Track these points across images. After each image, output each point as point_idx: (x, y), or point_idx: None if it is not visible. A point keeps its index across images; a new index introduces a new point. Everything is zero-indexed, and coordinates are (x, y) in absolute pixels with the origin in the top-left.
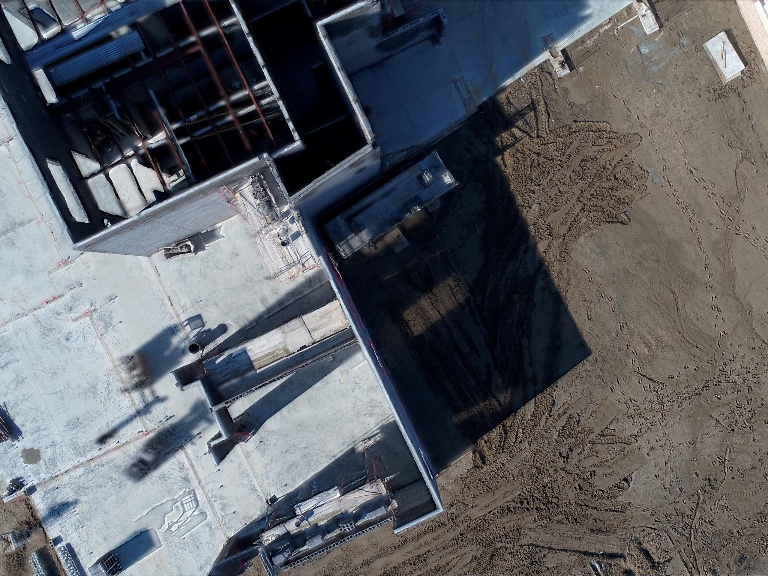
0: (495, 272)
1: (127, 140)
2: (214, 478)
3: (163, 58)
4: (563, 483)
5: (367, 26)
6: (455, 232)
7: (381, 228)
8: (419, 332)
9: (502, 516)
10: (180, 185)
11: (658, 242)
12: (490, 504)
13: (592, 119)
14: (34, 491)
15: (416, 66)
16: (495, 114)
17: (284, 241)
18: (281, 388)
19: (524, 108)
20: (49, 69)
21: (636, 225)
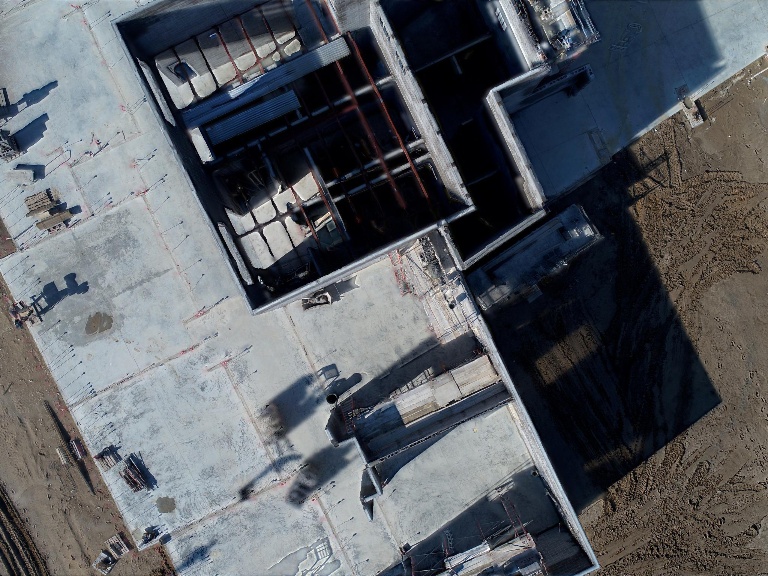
0: (627, 321)
1: (263, 191)
2: (348, 526)
3: (319, 117)
4: (693, 530)
5: (527, 87)
6: (587, 281)
7: (525, 282)
8: (551, 381)
9: (632, 563)
10: None
11: None
12: (620, 551)
13: (724, 169)
14: (169, 539)
15: (550, 117)
16: (628, 164)
17: (452, 304)
18: None
19: (657, 158)
20: (205, 128)
21: (767, 274)
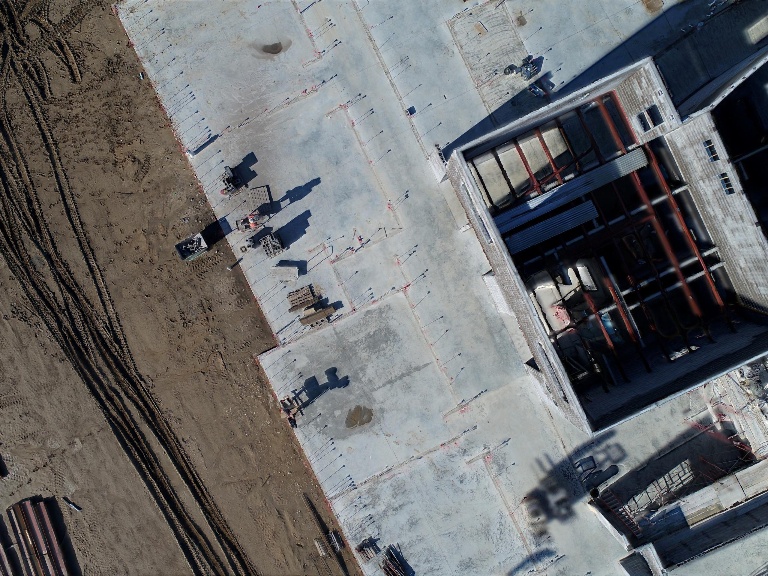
0: None
1: None
2: None
3: (616, 226)
4: None
5: None
6: None
7: None
8: None
9: None
10: (575, 330)
11: None
12: None
13: None
14: None
15: None
16: None
17: None
18: None
19: None
20: (504, 237)
21: None
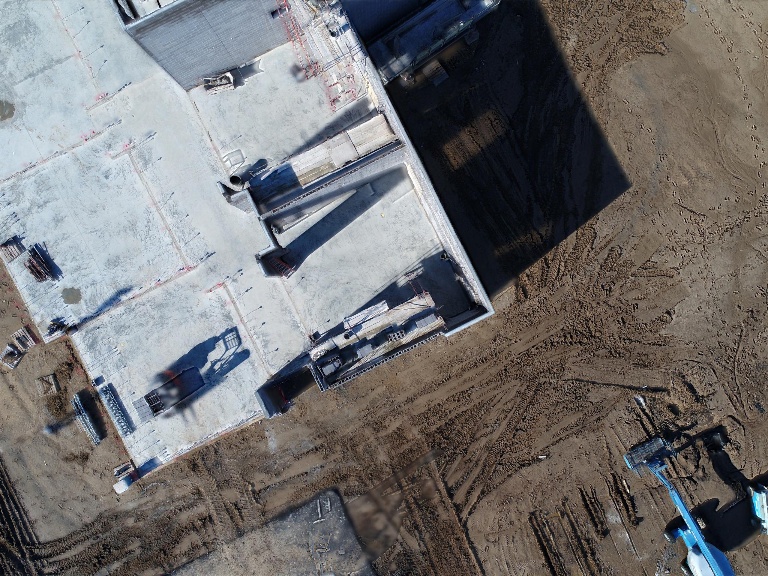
0: (535, 104)
1: None
2: (256, 315)
3: None
4: (606, 317)
5: None
6: (494, 64)
7: None
8: (459, 166)
9: (546, 351)
10: None
11: (697, 72)
12: (533, 339)
13: None
14: (75, 331)
15: None
16: None
17: (334, 31)
18: (322, 223)
19: None
20: None
21: (675, 55)
